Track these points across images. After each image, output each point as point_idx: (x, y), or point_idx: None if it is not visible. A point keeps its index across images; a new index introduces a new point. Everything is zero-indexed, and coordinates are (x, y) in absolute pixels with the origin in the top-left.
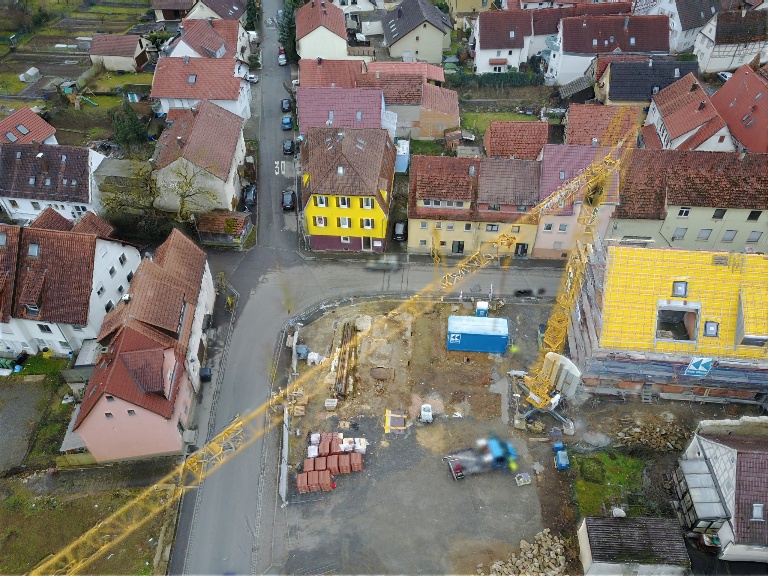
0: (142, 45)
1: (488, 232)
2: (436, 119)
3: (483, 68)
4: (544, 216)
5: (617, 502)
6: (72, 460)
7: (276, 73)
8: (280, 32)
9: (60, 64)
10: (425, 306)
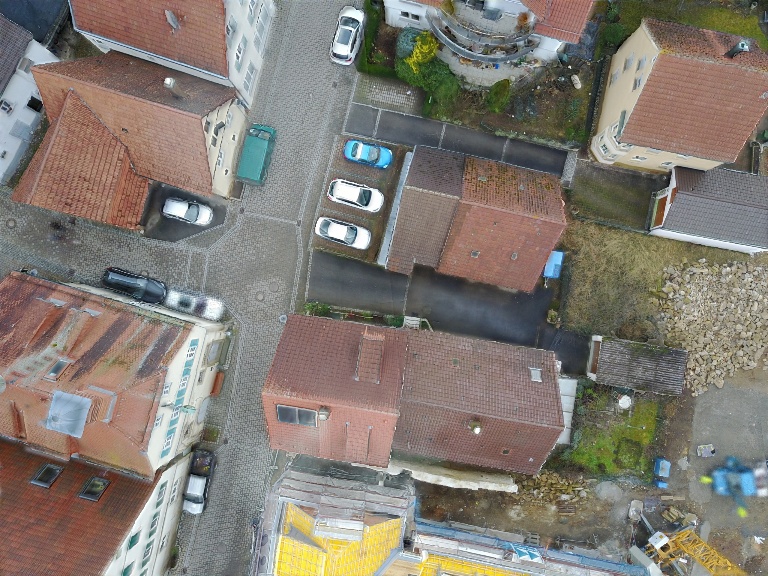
0: None
1: None
2: None
3: None
4: None
5: (616, 417)
6: None
7: None
8: None
9: None
10: None
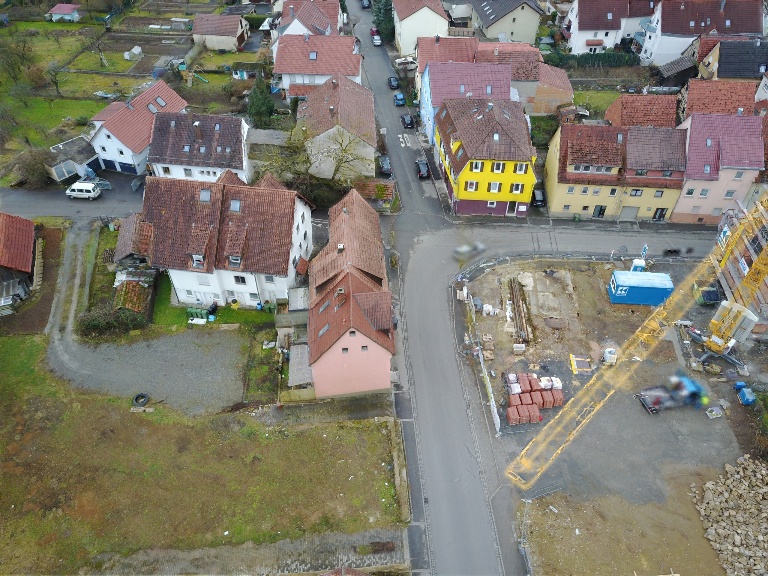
0: (242, 25)
1: (632, 197)
2: (551, 95)
3: (579, 49)
4: (689, 181)
5: None
6: (294, 396)
7: (373, 53)
8: (375, 13)
9: (158, 43)
10: (579, 264)
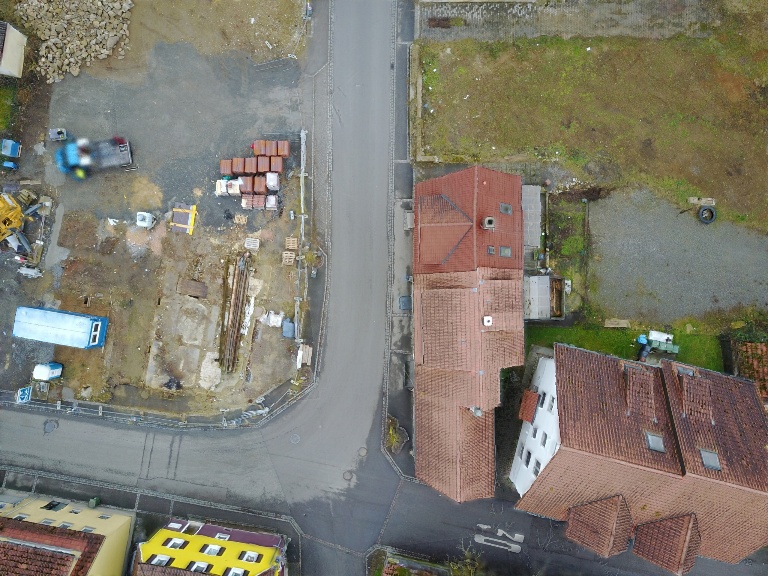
0: None
1: None
2: None
3: None
4: None
5: None
6: None
7: None
8: None
9: None
10: (126, 398)
